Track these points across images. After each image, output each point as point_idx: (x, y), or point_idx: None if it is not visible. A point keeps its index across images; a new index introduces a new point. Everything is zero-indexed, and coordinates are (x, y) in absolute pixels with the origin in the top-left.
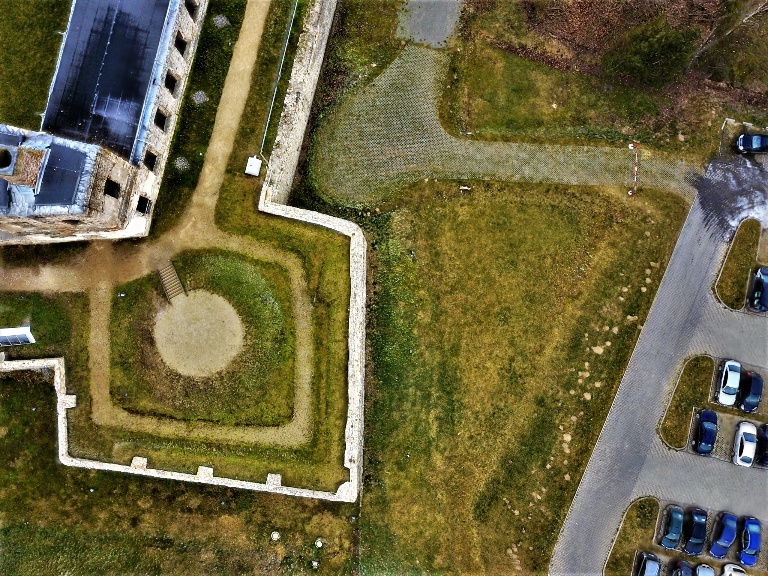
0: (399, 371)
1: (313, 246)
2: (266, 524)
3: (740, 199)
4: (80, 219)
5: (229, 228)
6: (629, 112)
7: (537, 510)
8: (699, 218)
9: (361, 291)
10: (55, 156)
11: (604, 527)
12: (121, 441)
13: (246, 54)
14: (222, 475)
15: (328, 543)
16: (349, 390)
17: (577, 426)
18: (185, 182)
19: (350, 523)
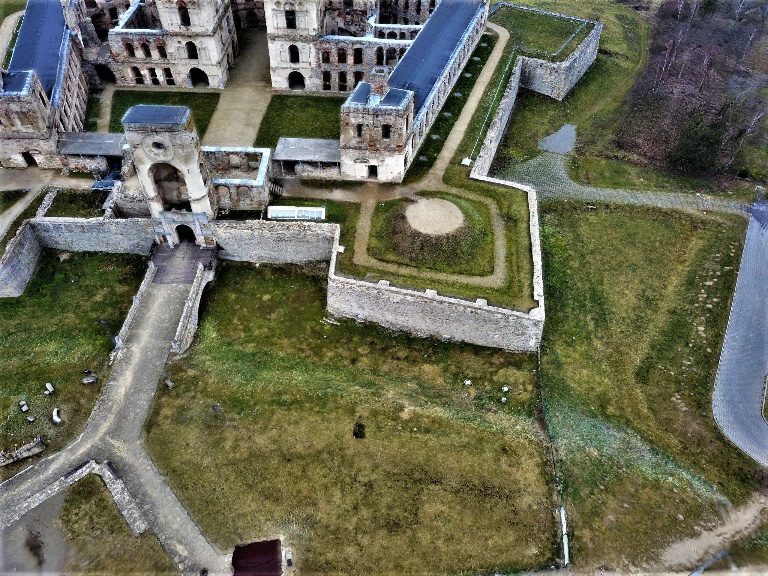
0: (559, 290)
1: (503, 195)
2: (460, 374)
3: None
4: (393, 125)
5: (451, 184)
6: (691, 186)
7: (690, 371)
8: (757, 225)
9: (537, 215)
10: (392, 91)
11: (752, 385)
12: (371, 273)
13: (461, 125)
14: (443, 296)
15: (513, 389)
16: (534, 259)
17: (707, 322)
18: (425, 165)
19: (531, 374)
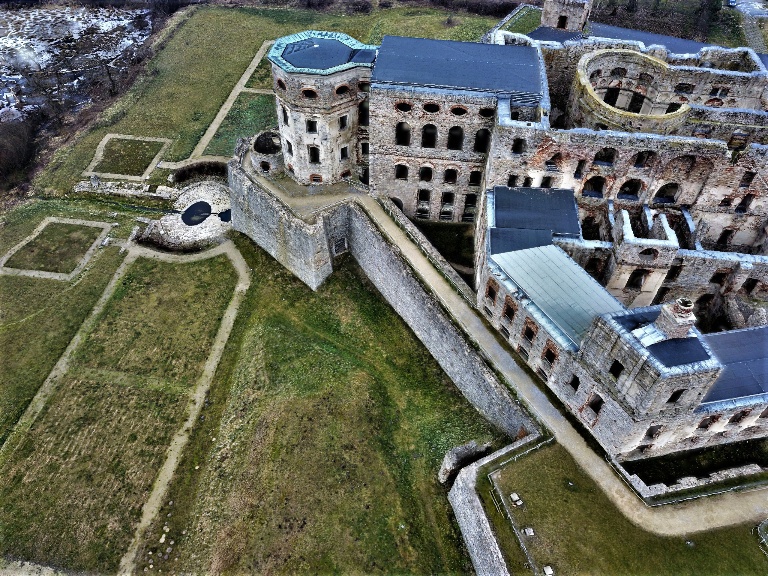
0: None
1: None
2: None
3: (756, 8)
4: None
5: None
6: None
7: None
8: (767, 15)
9: None
10: None
11: None
12: None
13: None
14: None
15: None
16: None
17: None
18: None
19: None
